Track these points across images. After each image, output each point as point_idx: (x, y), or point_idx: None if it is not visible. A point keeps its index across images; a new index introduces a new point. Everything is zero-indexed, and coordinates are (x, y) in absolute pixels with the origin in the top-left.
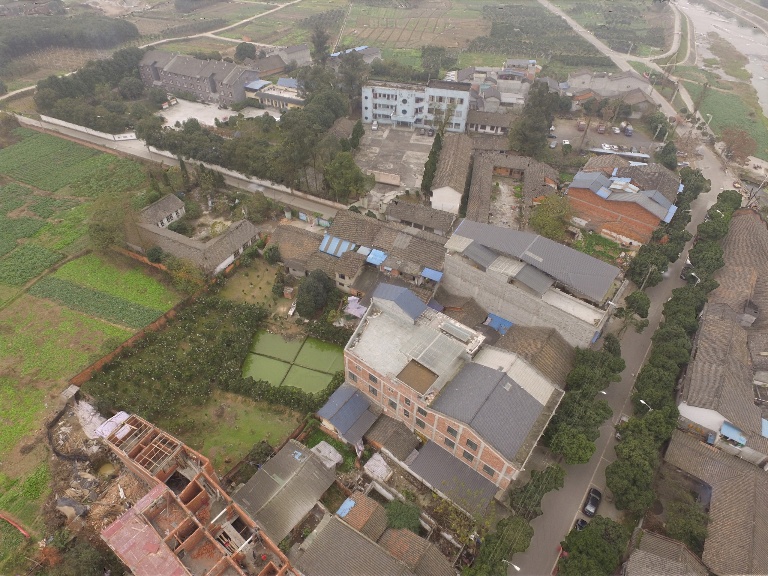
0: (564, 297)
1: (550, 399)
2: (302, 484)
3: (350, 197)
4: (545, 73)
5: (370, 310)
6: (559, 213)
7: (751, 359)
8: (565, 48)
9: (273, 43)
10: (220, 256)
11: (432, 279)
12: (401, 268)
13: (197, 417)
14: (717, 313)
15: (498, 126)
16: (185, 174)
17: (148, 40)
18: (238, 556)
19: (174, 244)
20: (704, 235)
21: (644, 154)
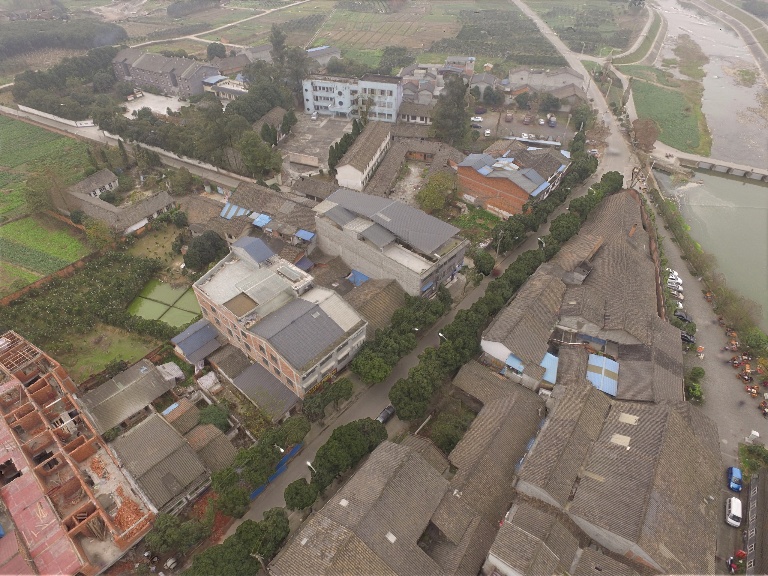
0: (405, 252)
1: (353, 327)
2: (139, 390)
3: (270, 176)
4: (496, 71)
5: (229, 257)
6: (440, 188)
7: (560, 307)
8: (525, 49)
9: (249, 45)
10: (132, 219)
11: (303, 238)
12: (280, 229)
13: (78, 343)
14: (546, 270)
15: (427, 117)
16: (122, 152)
17: (134, 42)
18: (61, 432)
19: (95, 208)
20: (572, 209)
21: (557, 142)
